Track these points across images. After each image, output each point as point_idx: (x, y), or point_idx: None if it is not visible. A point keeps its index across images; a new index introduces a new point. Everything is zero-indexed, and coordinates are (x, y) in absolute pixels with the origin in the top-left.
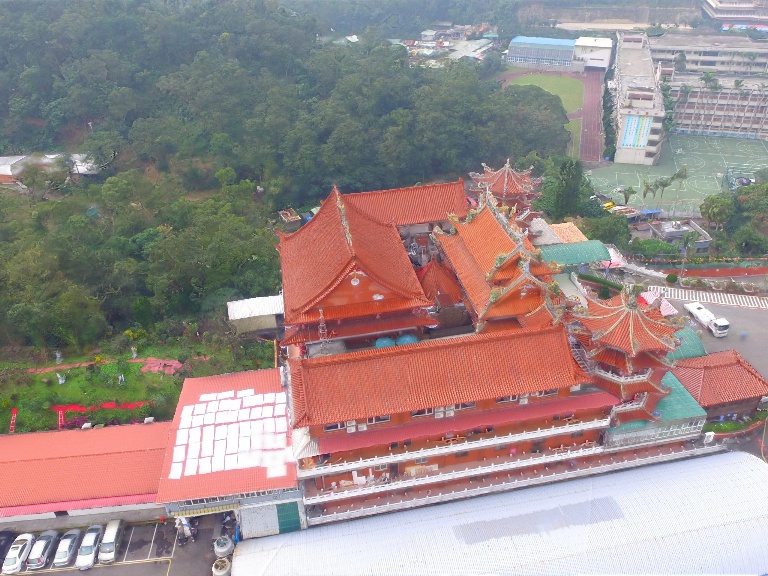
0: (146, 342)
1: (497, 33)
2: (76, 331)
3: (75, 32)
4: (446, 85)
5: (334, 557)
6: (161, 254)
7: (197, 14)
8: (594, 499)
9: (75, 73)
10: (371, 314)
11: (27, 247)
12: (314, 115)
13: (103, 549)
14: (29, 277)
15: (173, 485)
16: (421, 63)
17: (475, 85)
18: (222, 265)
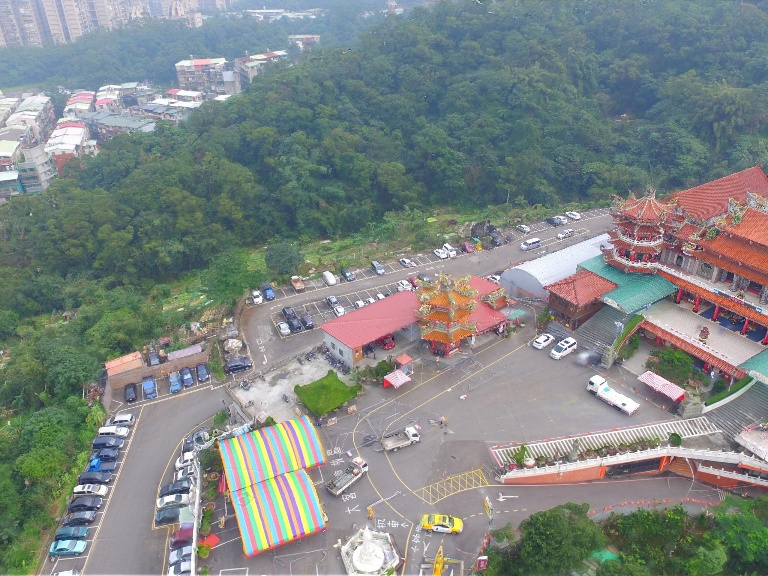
0: None
1: None
2: None
3: None
4: None
5: None
6: None
7: None
8: (607, 248)
9: None
10: None
11: None
12: None
13: None
14: None
15: None
16: None
17: None
18: None
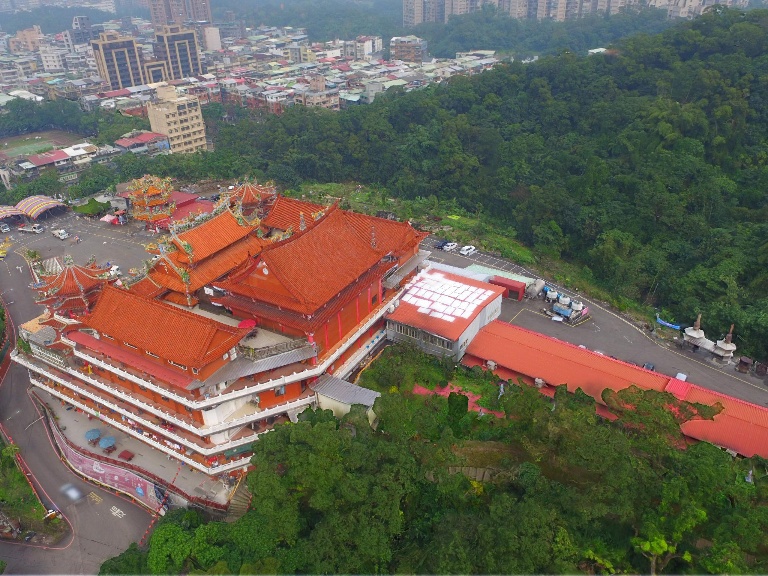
0: None
1: None
2: None
3: None
4: None
5: None
6: None
7: None
8: None
9: None
10: None
11: (585, 574)
12: None
13: None
14: None
15: None
16: None
17: None
18: None
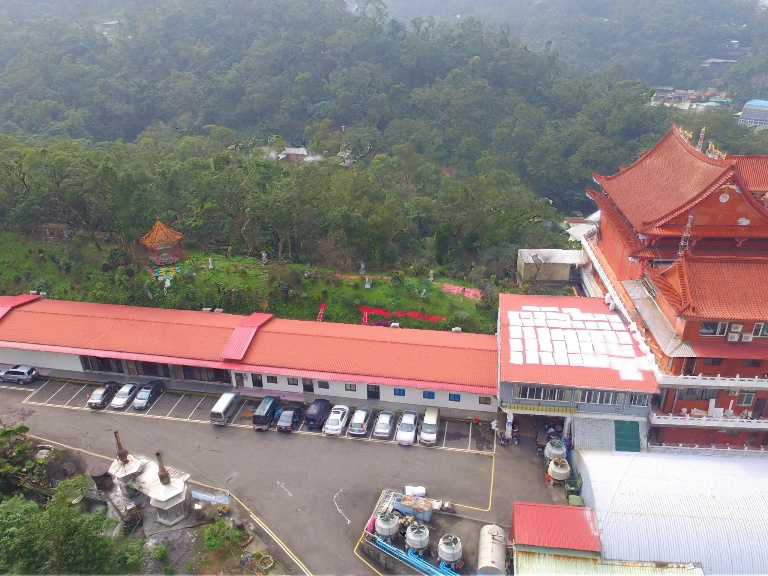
0: (439, 271)
1: (727, 97)
2: (381, 247)
3: (345, 48)
4: (699, 118)
5: (708, 474)
6: (454, 198)
7: (448, 43)
8: None
9: (342, 79)
10: (733, 239)
11: None
12: (560, 132)
13: (424, 429)
14: (346, 192)
15: (516, 368)
16: (665, 101)
17: (729, 122)
18: (504, 223)
